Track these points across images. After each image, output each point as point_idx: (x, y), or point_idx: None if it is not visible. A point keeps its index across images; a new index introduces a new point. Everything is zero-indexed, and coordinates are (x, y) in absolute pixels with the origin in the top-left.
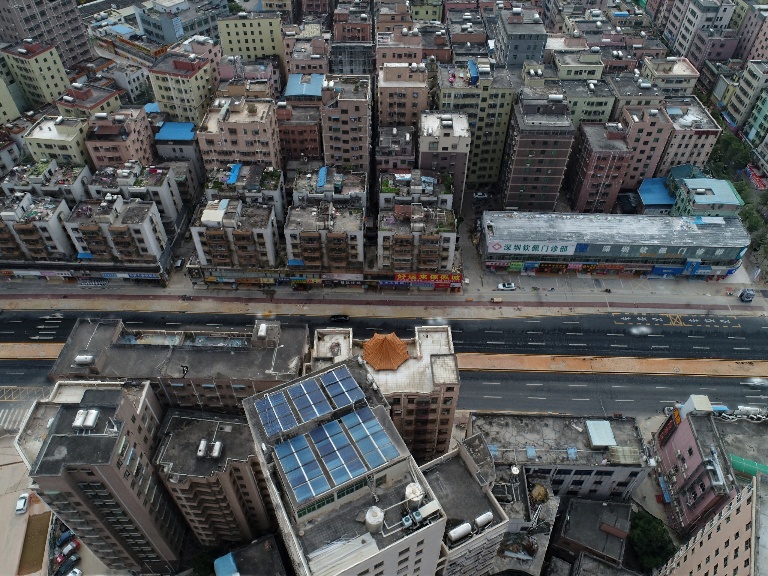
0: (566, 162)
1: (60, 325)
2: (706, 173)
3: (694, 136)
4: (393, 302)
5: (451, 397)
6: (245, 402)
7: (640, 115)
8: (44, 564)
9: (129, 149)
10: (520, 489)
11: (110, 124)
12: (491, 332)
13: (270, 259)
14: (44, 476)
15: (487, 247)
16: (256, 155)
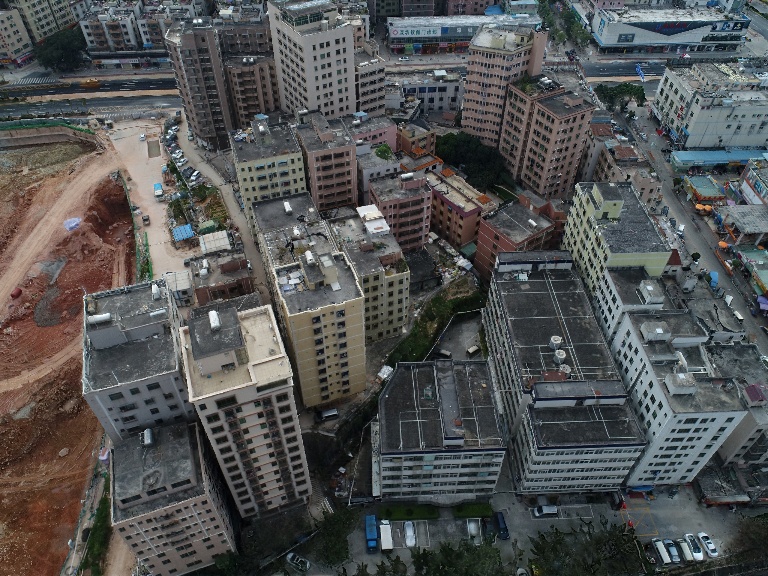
0: None
1: (137, 84)
2: None
3: None
4: None
5: (360, 36)
6: (268, 1)
7: None
8: (162, 153)
9: None
10: (400, 92)
11: None
12: None
13: None
14: (186, 34)
15: (390, 34)
16: None
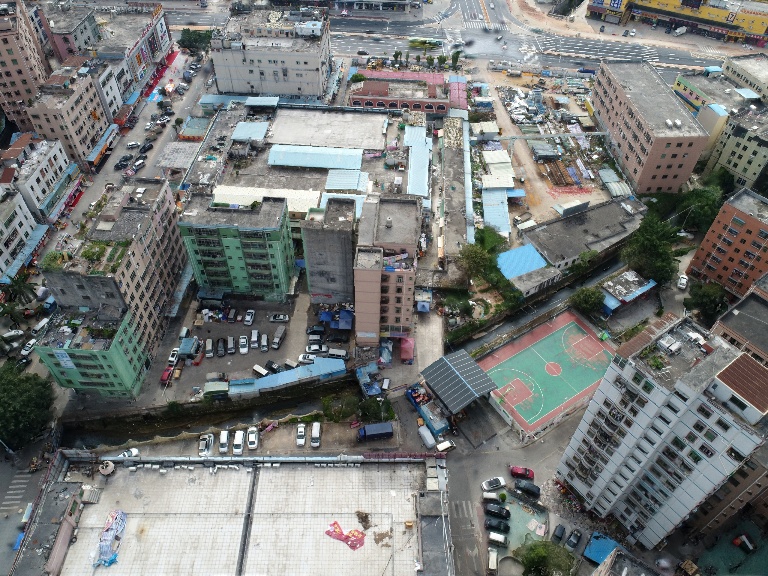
0: None
1: None
2: None
3: None
4: None
5: None
6: None
7: None
8: None
9: None
10: None
11: None
12: None
13: None
14: None
15: None
16: None
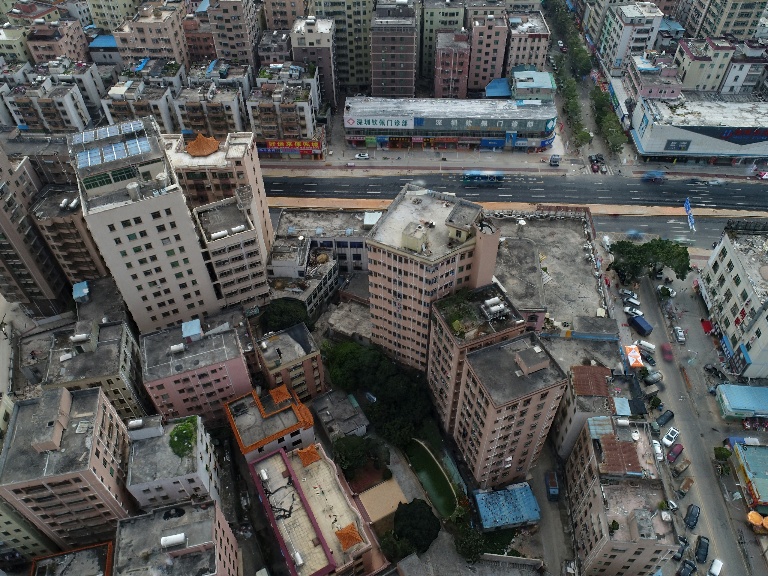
0: (414, 57)
1: None
2: (558, 80)
3: (529, 39)
4: (267, 166)
5: (242, 172)
6: (68, 136)
7: (483, 22)
8: None
9: (62, 48)
10: (303, 250)
11: (47, 28)
12: (340, 185)
13: (167, 129)
14: None
15: (344, 122)
16: (162, 52)
